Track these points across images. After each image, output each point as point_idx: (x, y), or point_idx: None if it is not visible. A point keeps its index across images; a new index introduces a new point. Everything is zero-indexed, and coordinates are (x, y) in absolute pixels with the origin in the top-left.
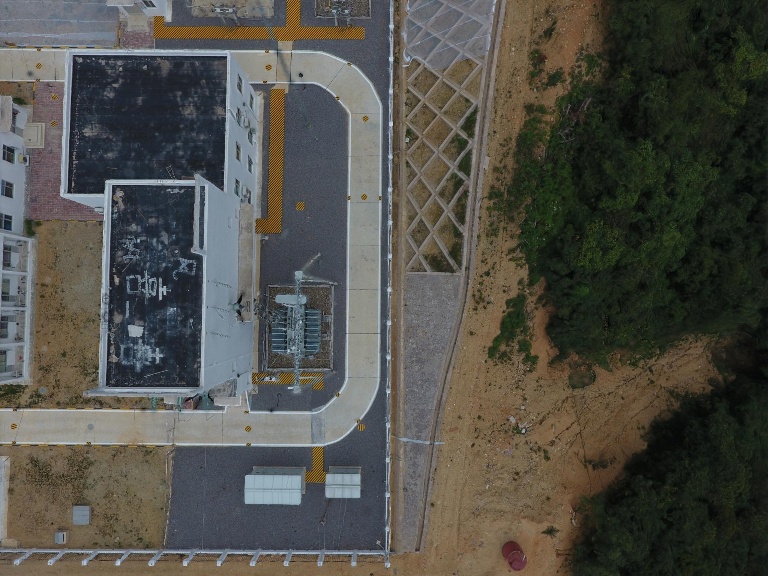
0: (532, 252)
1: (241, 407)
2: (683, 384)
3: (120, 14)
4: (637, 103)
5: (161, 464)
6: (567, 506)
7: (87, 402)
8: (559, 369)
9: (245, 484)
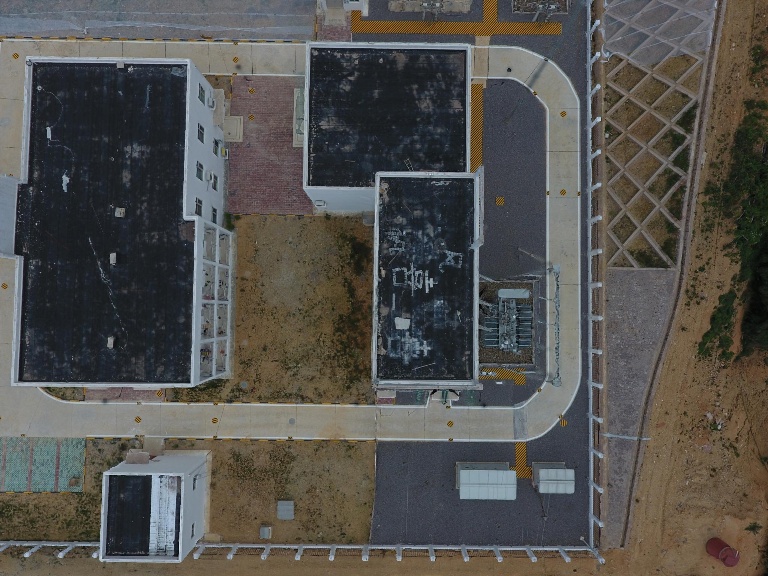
0: (747, 248)
1: None
2: None
3: (322, 8)
4: None
5: (364, 459)
6: (764, 503)
7: (288, 396)
8: (734, 366)
9: (461, 479)
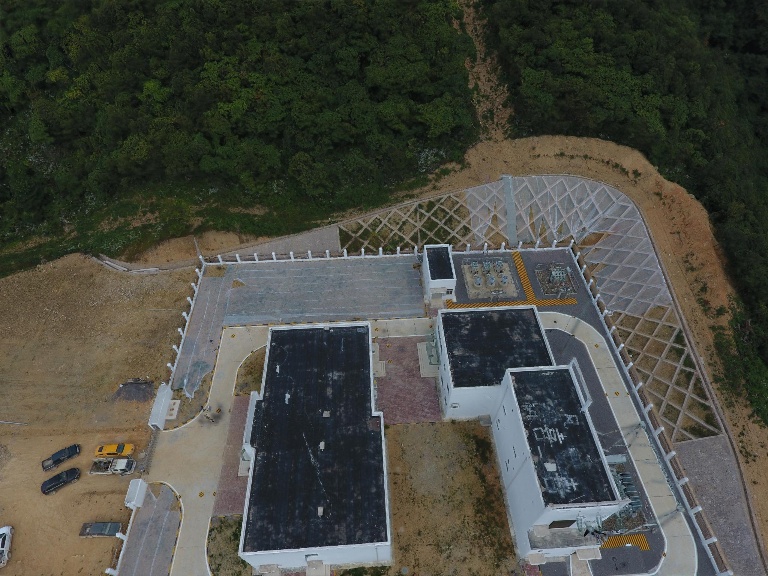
0: (765, 416)
1: (585, 574)
2: None
3: None
4: None
5: None
6: None
7: None
8: None
9: None
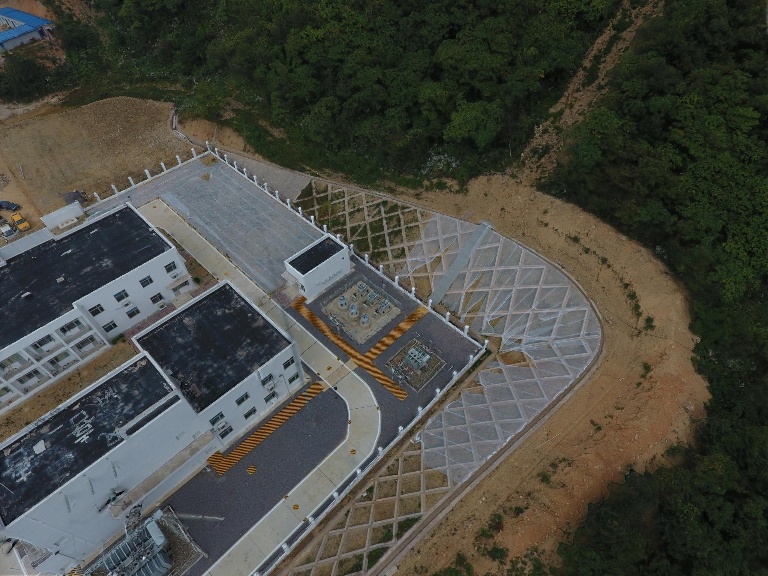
0: None
1: None
2: None
3: (286, 282)
4: None
5: None
6: None
7: None
8: None
9: None
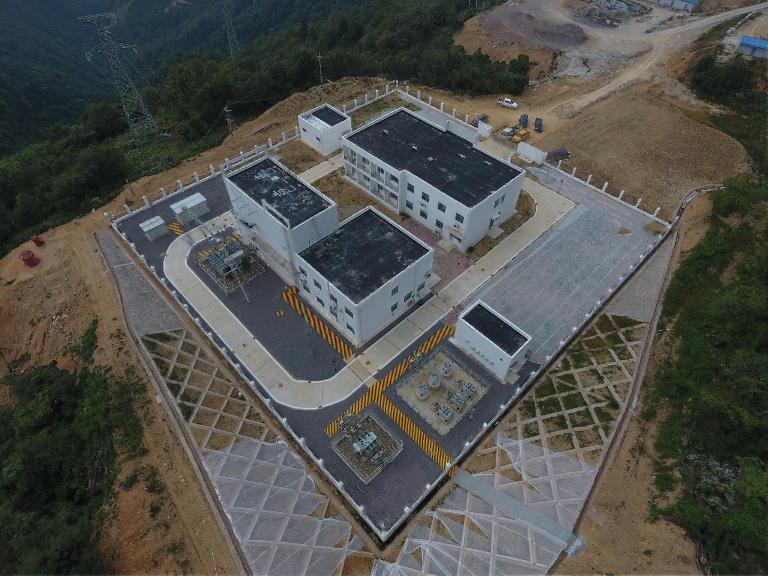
0: None
1: None
2: None
3: None
4: None
5: None
6: (3, 304)
7: None
8: None
9: None
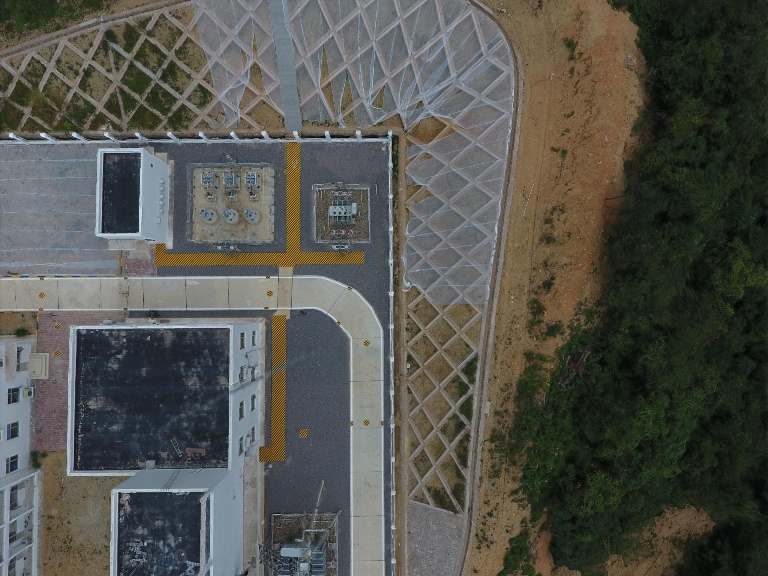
0: (534, 493)
1: None
2: (685, 526)
3: None
4: (636, 358)
5: None
6: None
7: None
8: None
9: None
